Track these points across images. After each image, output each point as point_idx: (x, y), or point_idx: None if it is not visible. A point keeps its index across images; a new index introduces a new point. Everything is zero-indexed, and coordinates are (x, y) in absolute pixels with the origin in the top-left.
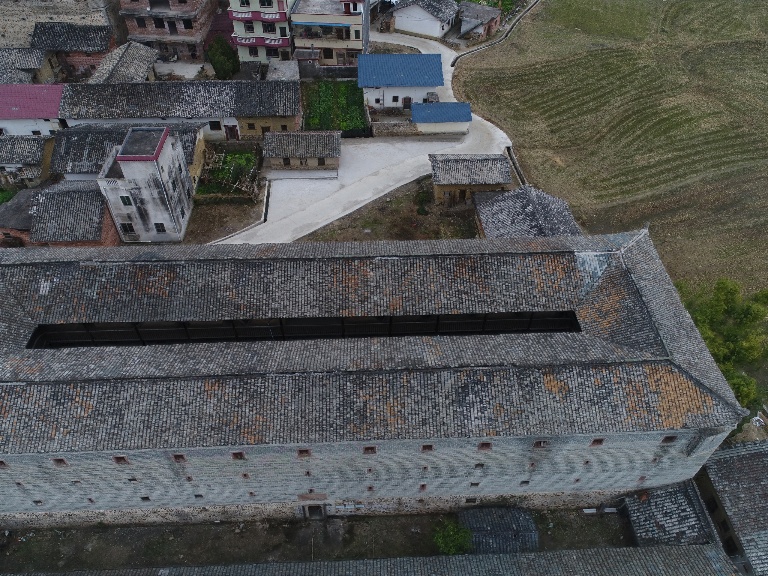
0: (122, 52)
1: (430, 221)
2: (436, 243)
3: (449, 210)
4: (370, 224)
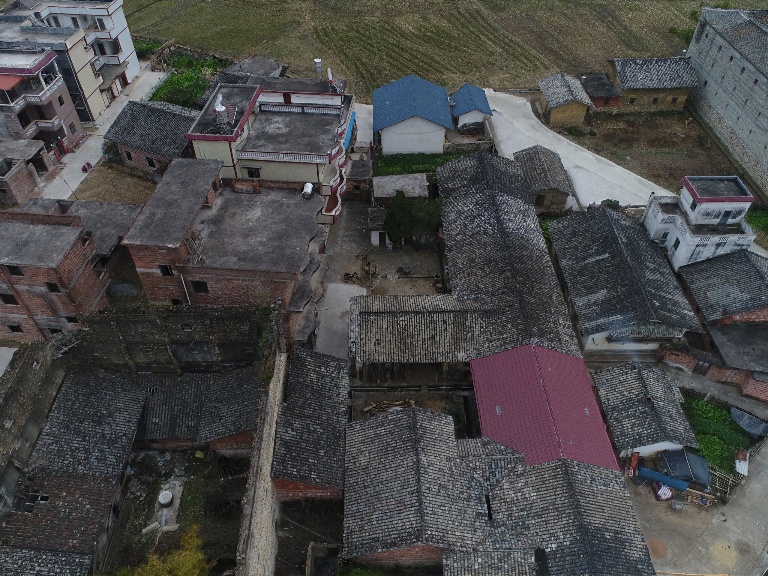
0: (390, 319)
1: (603, 131)
2: (760, 59)
3: (585, 123)
4: (619, 157)
